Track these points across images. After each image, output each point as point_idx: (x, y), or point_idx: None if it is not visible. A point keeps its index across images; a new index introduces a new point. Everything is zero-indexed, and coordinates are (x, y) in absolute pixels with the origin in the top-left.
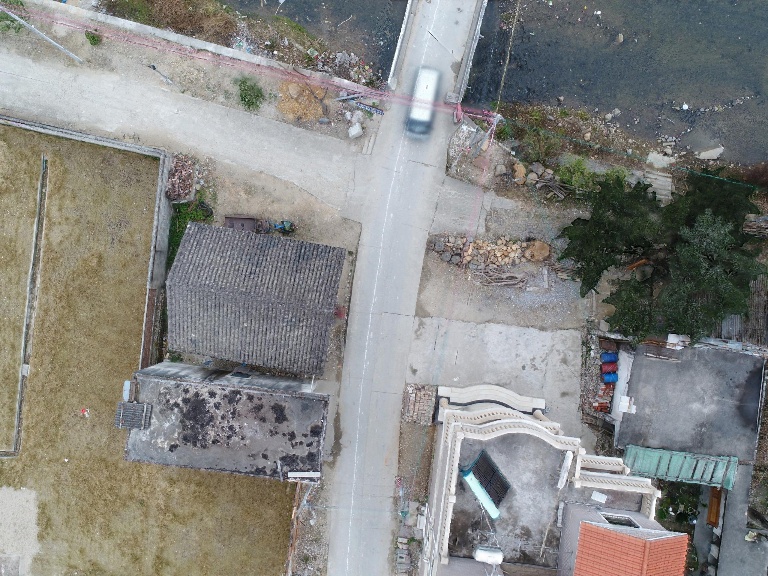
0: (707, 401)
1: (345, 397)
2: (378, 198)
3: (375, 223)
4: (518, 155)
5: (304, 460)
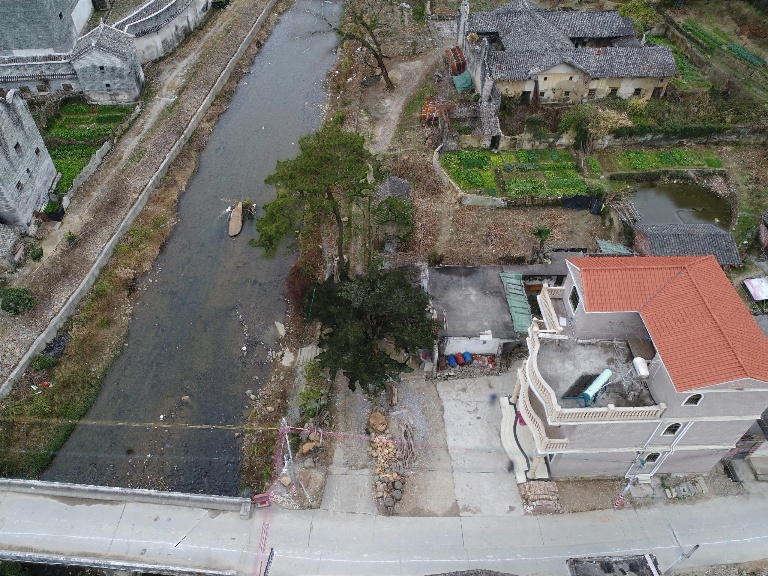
0: (467, 293)
1: (560, 574)
2: (350, 573)
3: (376, 572)
4: (292, 456)
5: (641, 575)
